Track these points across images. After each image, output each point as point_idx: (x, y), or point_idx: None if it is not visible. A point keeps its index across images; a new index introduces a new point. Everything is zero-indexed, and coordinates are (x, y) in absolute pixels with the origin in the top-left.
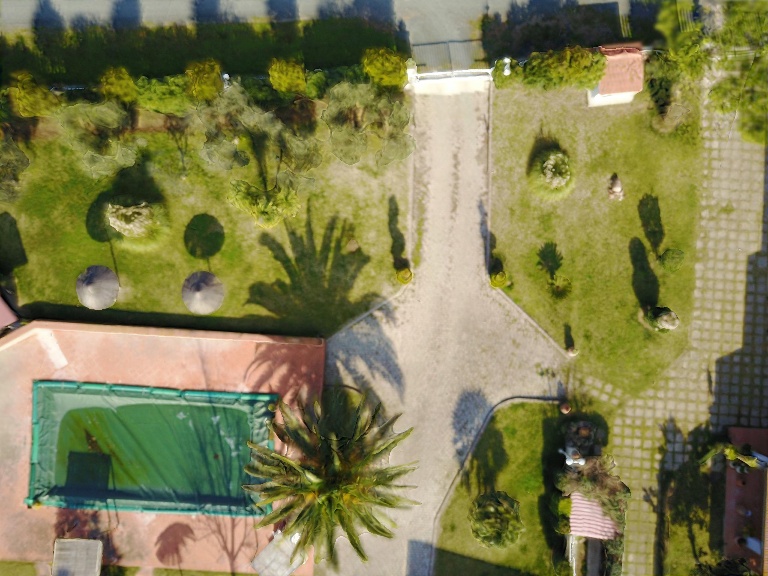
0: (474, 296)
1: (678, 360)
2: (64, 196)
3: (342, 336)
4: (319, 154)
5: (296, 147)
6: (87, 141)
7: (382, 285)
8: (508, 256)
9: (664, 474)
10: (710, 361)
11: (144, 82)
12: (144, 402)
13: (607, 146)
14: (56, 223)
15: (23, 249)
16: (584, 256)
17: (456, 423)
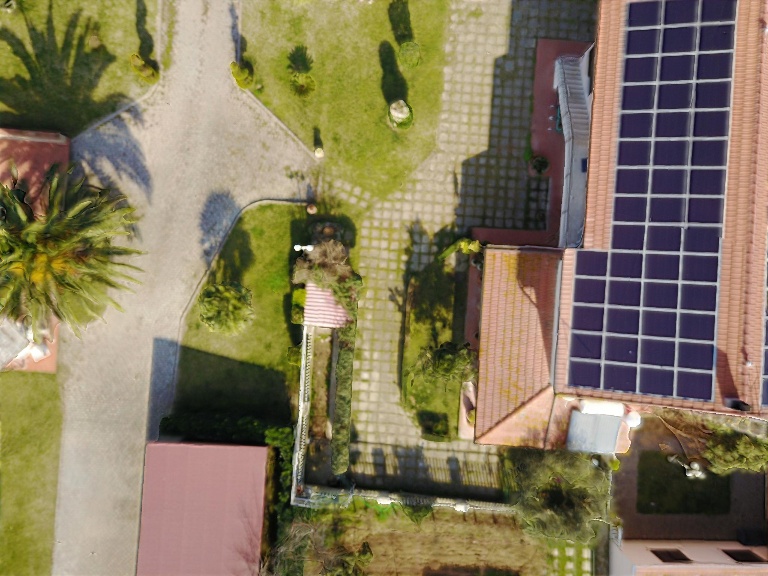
0: (224, 99)
1: (425, 162)
2: None
3: (88, 137)
4: None
5: None
6: None
7: (129, 86)
8: (259, 59)
9: (410, 274)
10: (457, 163)
11: None
12: None
13: None
14: None
15: None
16: (334, 59)
17: (204, 225)
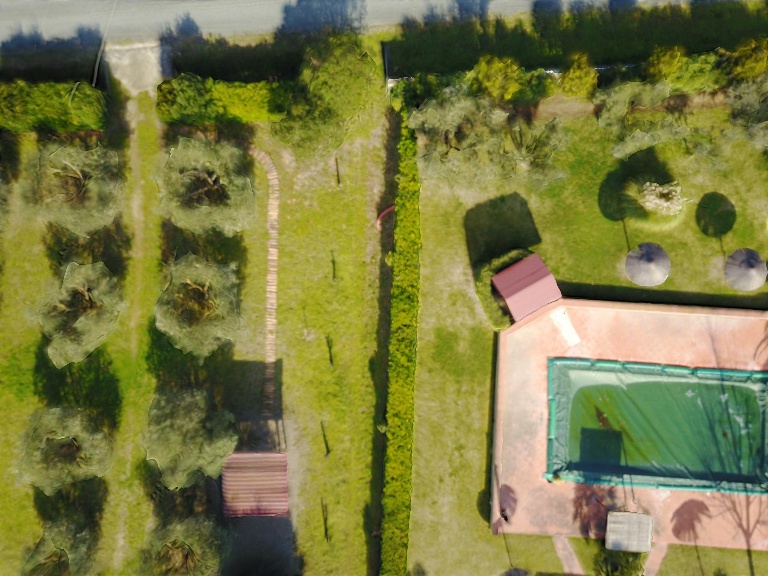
0: None
1: None
2: (572, 176)
3: None
4: None
5: None
6: (621, 120)
7: None
8: None
9: None
10: None
11: None
12: (655, 379)
13: None
14: (568, 202)
15: (536, 228)
16: None
17: None
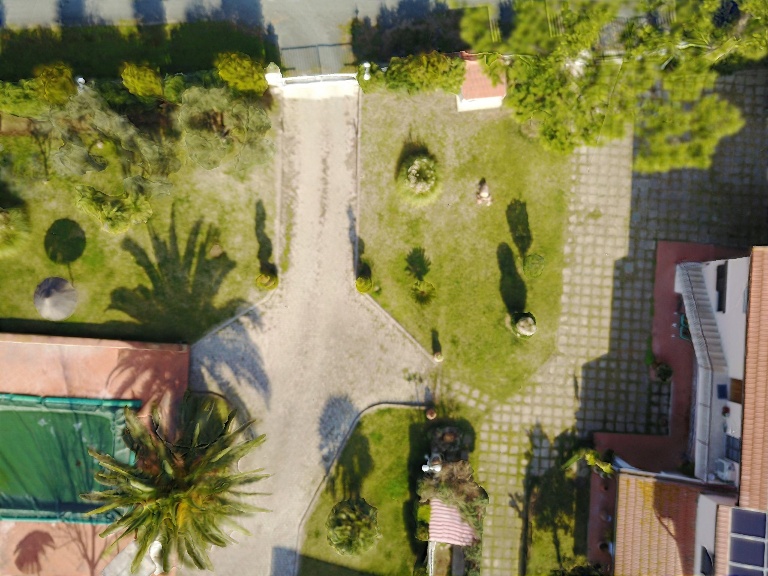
0: (342, 301)
1: (545, 365)
2: None
3: (207, 342)
4: (176, 159)
5: (144, 152)
6: None
7: (248, 290)
8: (376, 261)
9: (530, 479)
10: (576, 366)
11: None
12: (4, 409)
13: (476, 151)
14: None
15: None
16: (452, 261)
17: (322, 429)
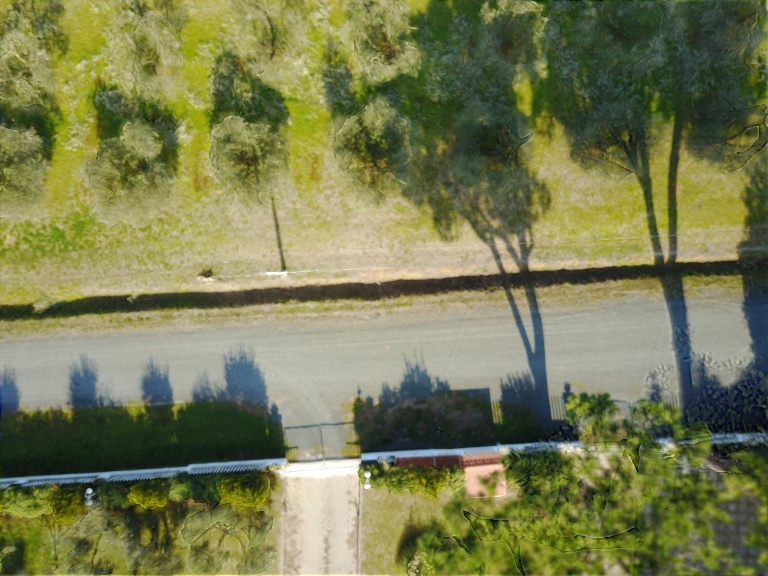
0: None
1: None
2: None
3: None
4: (180, 567)
5: None
6: None
7: None
8: None
9: None
10: None
11: (10, 493)
12: None
13: None
14: None
15: None
16: None
17: None
